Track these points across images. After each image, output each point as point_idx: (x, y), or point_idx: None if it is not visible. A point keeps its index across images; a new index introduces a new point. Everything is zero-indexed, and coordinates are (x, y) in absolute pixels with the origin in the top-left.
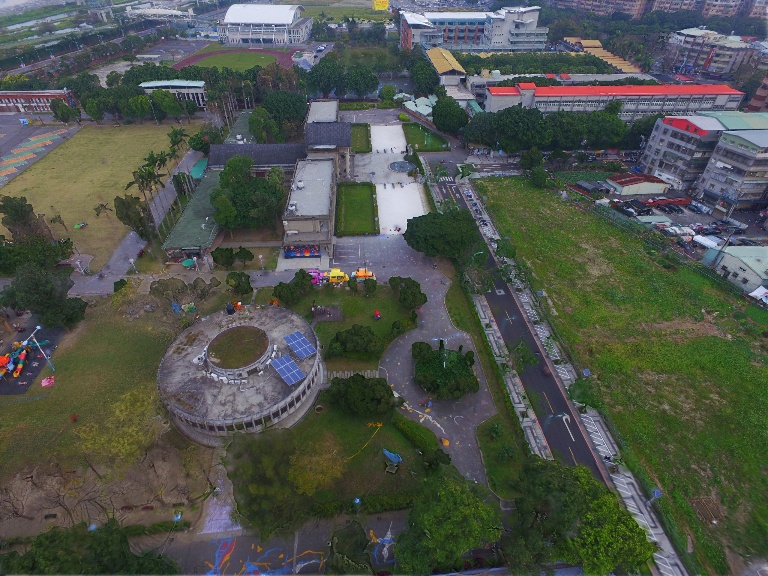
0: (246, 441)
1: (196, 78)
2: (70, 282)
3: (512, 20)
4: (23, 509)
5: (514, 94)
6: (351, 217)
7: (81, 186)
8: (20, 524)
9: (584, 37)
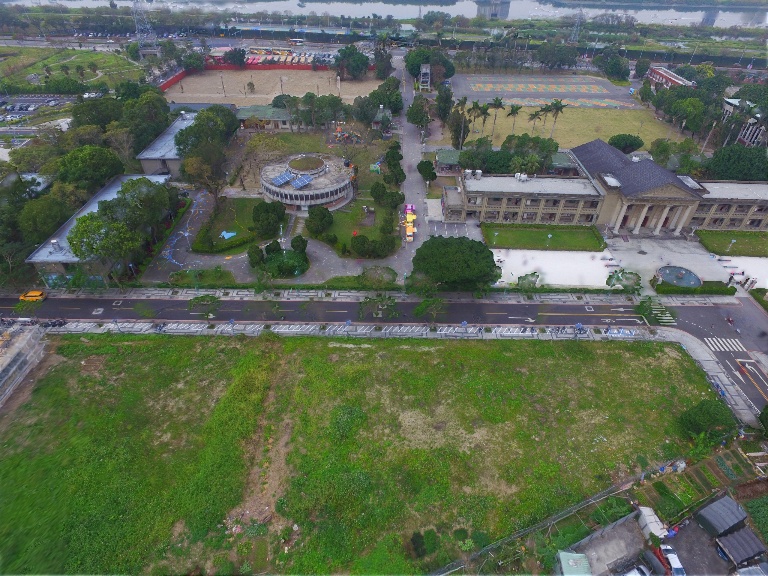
0: None
1: None
2: (371, 117)
3: None
4: None
5: None
6: (520, 233)
7: None
8: None
9: None
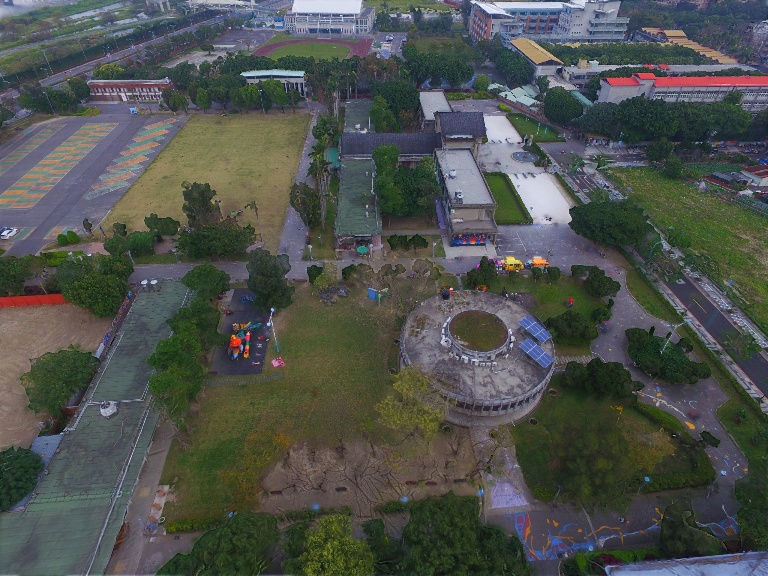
0: (583, 418)
1: (295, 68)
2: (289, 266)
3: (593, 10)
4: (311, 482)
5: (633, 84)
6: None
7: (218, 174)
8: (317, 496)
9: (664, 27)
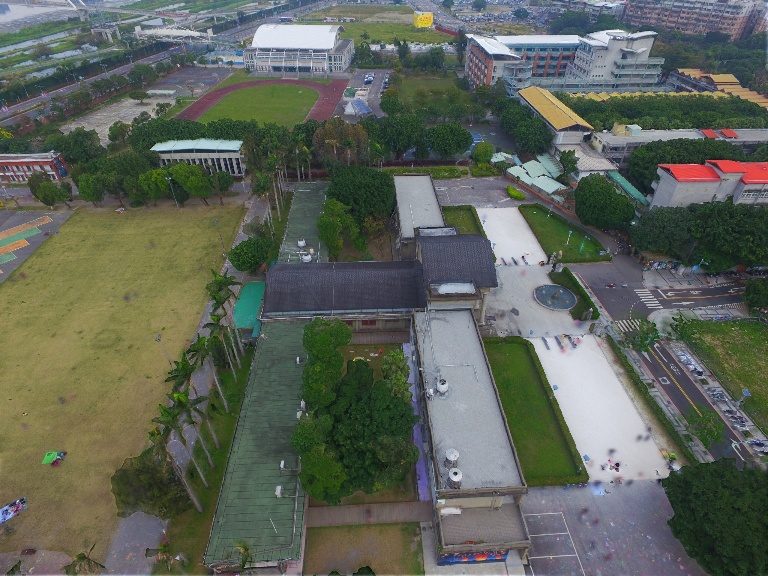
0: None
1: (229, 137)
2: None
3: (619, 48)
4: None
5: (711, 179)
6: (519, 428)
7: (62, 345)
8: None
9: (707, 69)
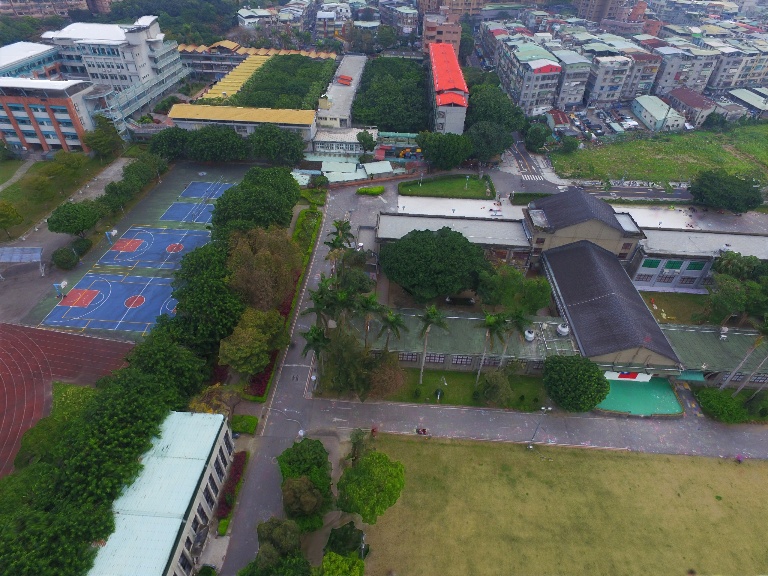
0: None
1: (151, 434)
2: None
3: (144, 41)
4: None
5: None
6: None
7: None
8: None
9: (197, 41)
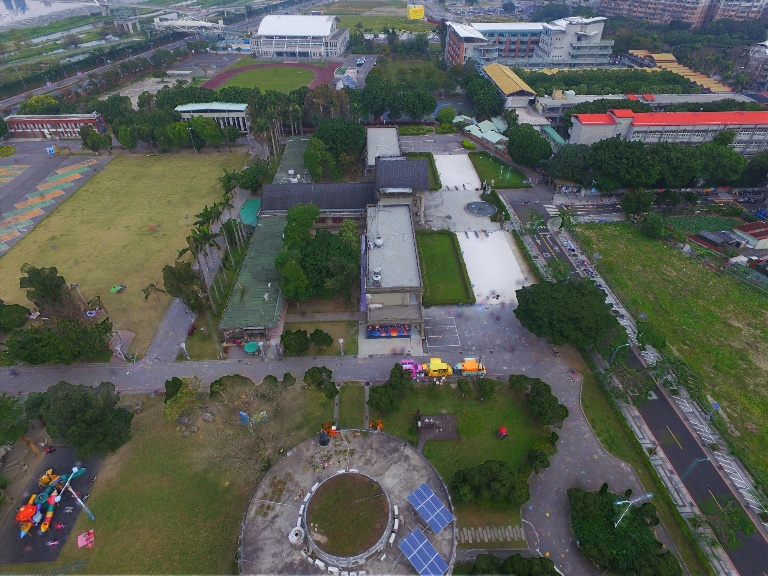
0: None
1: (237, 100)
2: (115, 398)
3: (574, 32)
4: None
5: (608, 123)
6: (436, 278)
7: (116, 234)
8: None
9: (653, 50)
